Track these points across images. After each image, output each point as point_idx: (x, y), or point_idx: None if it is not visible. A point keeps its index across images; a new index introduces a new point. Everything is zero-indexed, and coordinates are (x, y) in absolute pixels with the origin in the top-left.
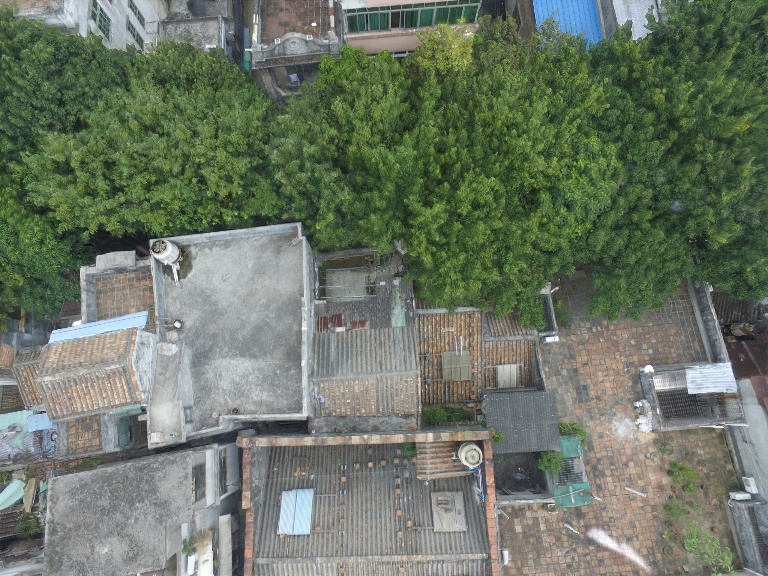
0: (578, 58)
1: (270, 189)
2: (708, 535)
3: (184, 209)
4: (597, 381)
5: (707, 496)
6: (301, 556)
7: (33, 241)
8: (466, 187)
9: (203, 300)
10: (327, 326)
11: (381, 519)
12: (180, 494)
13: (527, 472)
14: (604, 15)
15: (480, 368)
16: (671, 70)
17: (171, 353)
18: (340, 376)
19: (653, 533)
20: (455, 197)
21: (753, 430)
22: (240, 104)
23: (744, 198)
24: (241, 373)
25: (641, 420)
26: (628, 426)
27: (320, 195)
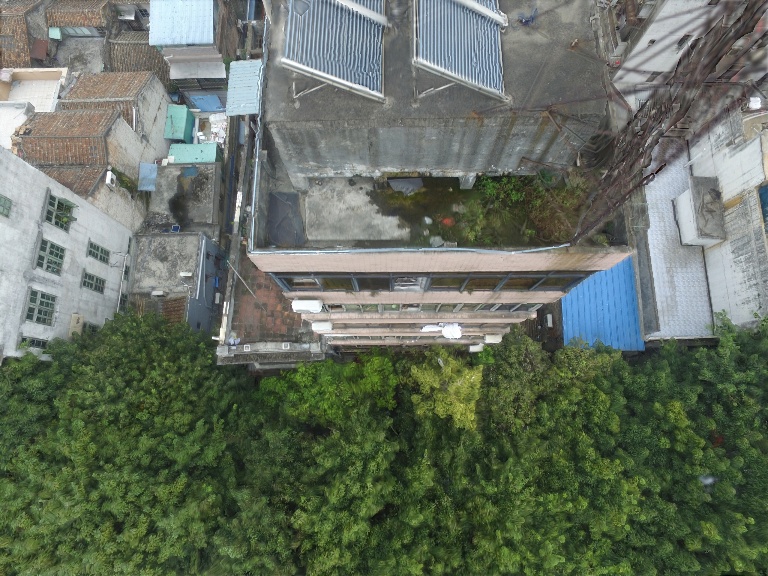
0: (609, 404)
1: None
2: None
3: None
4: None
5: None
6: None
7: None
8: None
9: None
10: None
11: None
12: None
13: None
14: (643, 301)
15: None
16: (726, 462)
17: None
18: None
19: None
20: None
21: None
22: (184, 477)
23: None
24: None
25: None
26: None
27: None
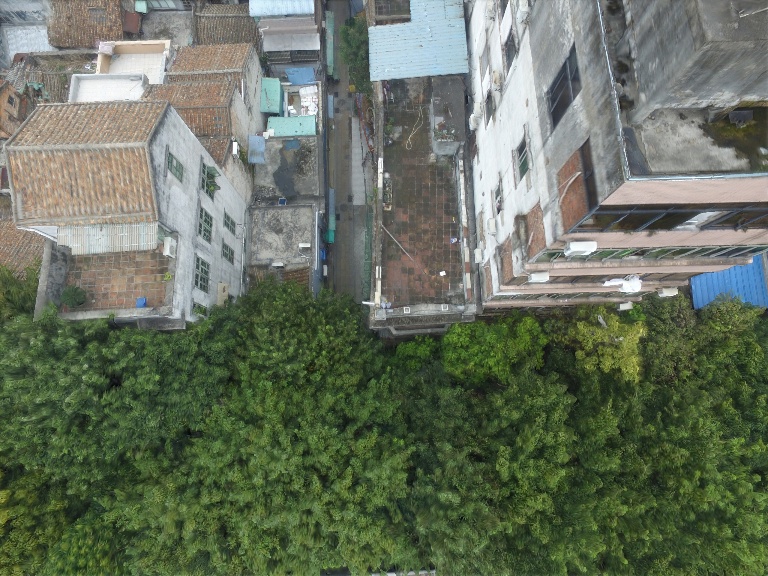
0: (763, 355)
1: (413, 554)
2: None
3: None
4: None
5: None
6: None
7: None
8: None
9: None
10: None
11: None
12: None
13: None
14: None
15: None
16: None
17: None
18: None
19: None
20: None
21: None
22: None
23: None
24: None
25: None
26: None
27: (476, 571)
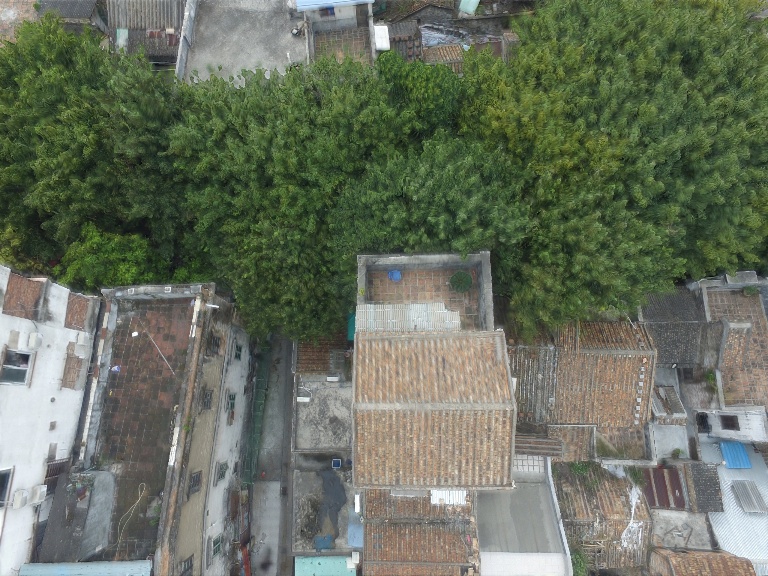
0: None
1: None
2: None
3: None
4: None
5: None
6: None
7: None
8: None
9: (276, 53)
10: None
11: None
12: None
13: None
14: None
15: None
16: None
17: (292, 0)
18: None
19: None
20: None
21: None
22: None
23: None
24: (249, 1)
25: None
26: (4, 15)
27: None
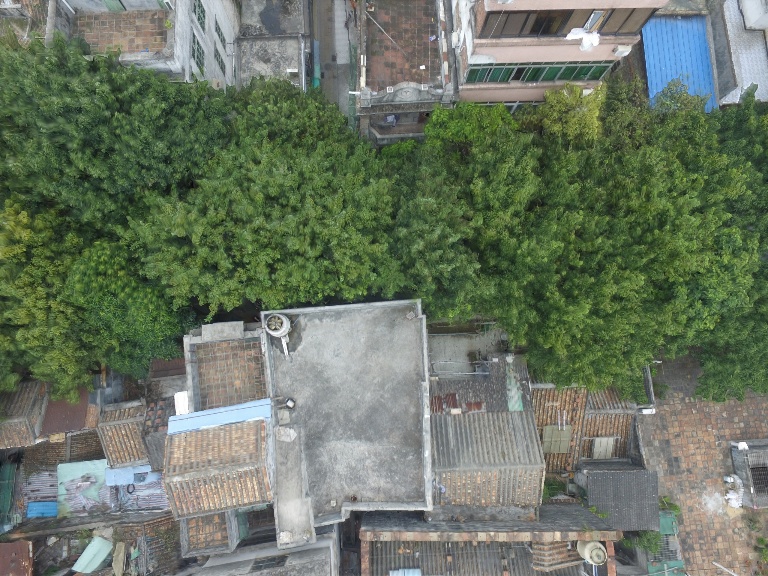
0: (707, 128)
1: (398, 270)
2: None
3: None
4: (689, 453)
5: None
6: None
7: (148, 320)
8: (612, 283)
9: (314, 376)
10: (442, 407)
11: None
12: None
13: None
14: (719, 69)
15: (579, 441)
16: None
17: (290, 439)
18: (463, 467)
19: None
20: (596, 290)
21: None
22: (364, 171)
23: None
24: (357, 457)
25: (731, 496)
26: (718, 500)
27: (453, 280)
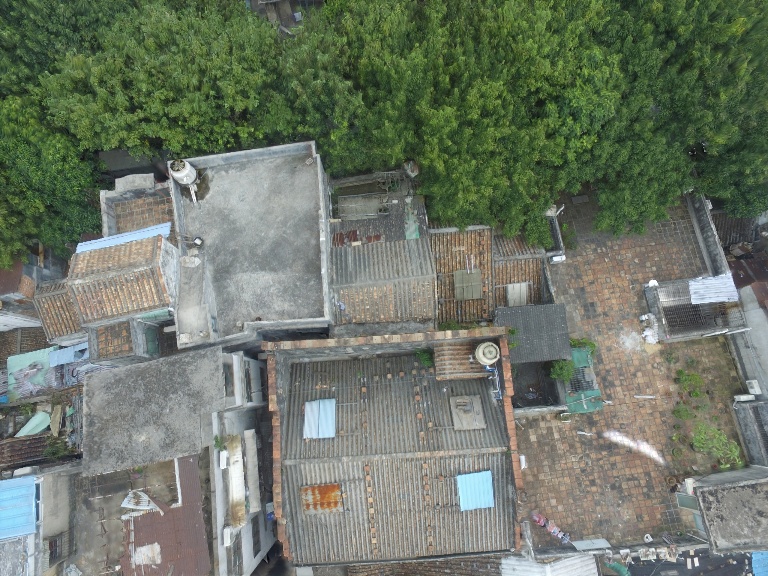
0: None
1: (285, 104)
2: (716, 431)
3: (201, 128)
4: (604, 298)
5: (713, 401)
6: (327, 456)
7: (56, 157)
8: (476, 93)
9: (222, 219)
10: (343, 241)
11: (402, 422)
12: (212, 385)
13: (538, 392)
14: None
15: (491, 287)
16: None
17: (194, 265)
18: (359, 283)
19: (662, 437)
20: (465, 105)
21: (755, 334)
22: None
23: (741, 103)
24: (262, 286)
25: (647, 332)
26: (635, 339)
27: (334, 108)
